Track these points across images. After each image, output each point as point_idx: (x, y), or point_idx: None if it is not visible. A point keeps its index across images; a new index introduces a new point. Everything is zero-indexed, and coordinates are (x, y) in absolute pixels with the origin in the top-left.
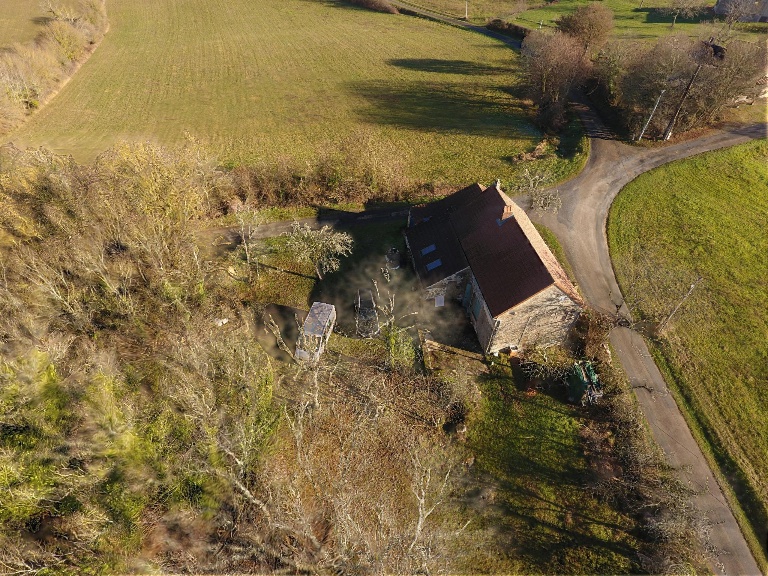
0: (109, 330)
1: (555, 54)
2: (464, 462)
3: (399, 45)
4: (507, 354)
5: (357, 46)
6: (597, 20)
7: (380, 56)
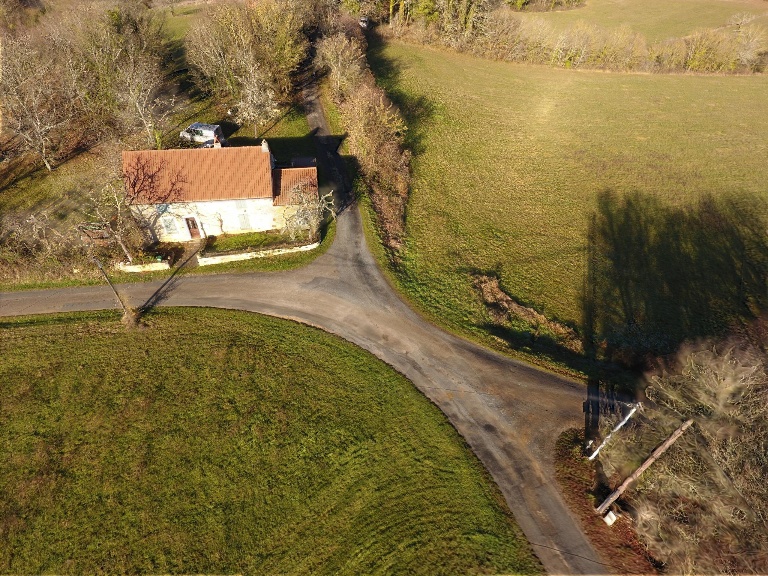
0: None
1: None
2: None
3: None
4: None
5: None
6: None
7: None
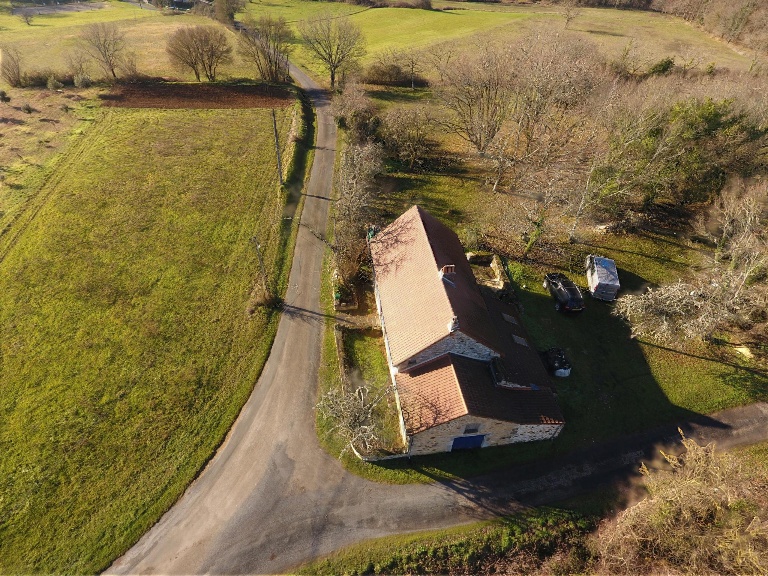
0: None
1: None
2: None
3: None
4: None
5: None
6: None
7: None
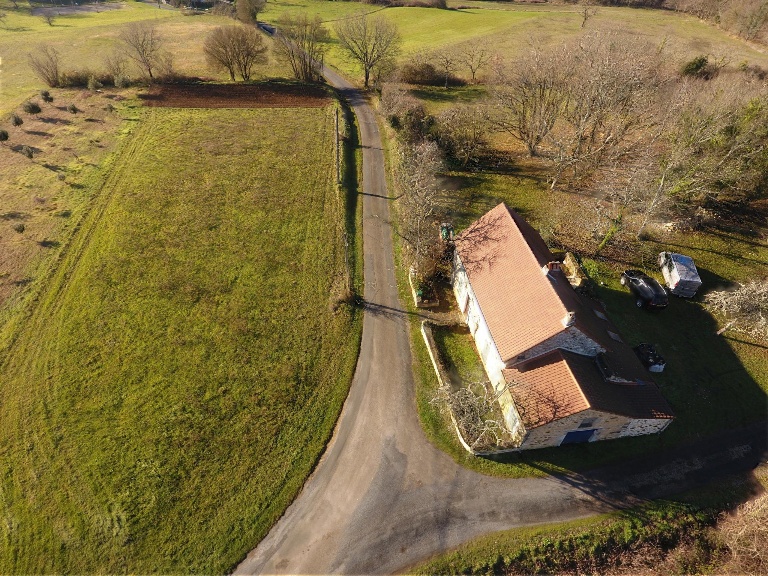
0: None
1: None
2: None
3: None
4: None
5: None
6: None
7: None
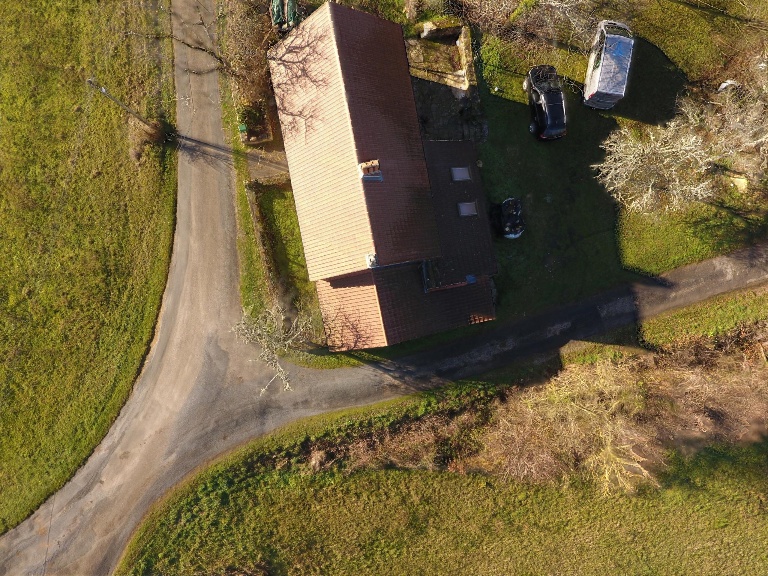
0: None
1: None
2: None
3: None
4: None
5: None
6: None
7: None
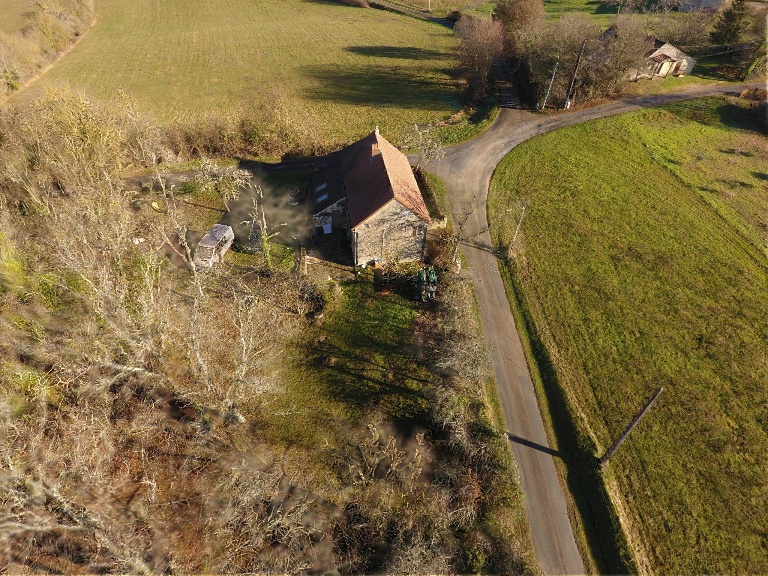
0: (37, 237)
1: (484, 37)
2: (317, 339)
3: (360, 35)
4: (373, 266)
5: (321, 36)
6: (527, 7)
7: (340, 44)
